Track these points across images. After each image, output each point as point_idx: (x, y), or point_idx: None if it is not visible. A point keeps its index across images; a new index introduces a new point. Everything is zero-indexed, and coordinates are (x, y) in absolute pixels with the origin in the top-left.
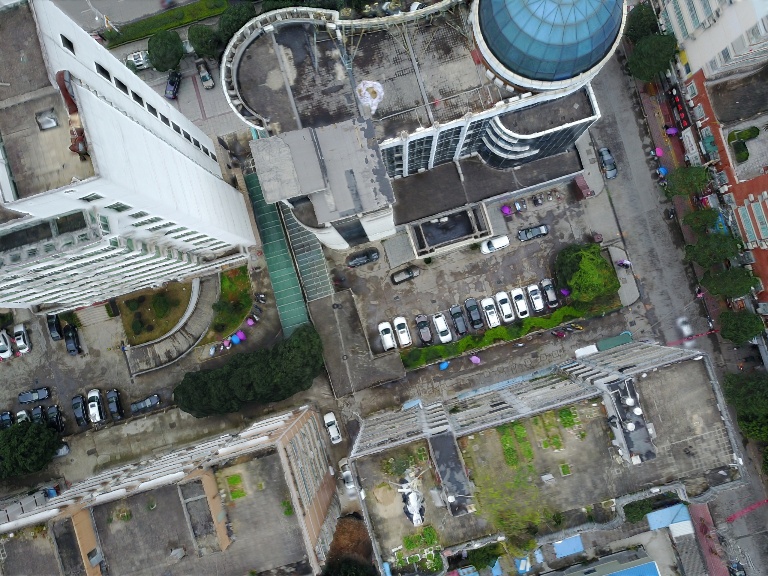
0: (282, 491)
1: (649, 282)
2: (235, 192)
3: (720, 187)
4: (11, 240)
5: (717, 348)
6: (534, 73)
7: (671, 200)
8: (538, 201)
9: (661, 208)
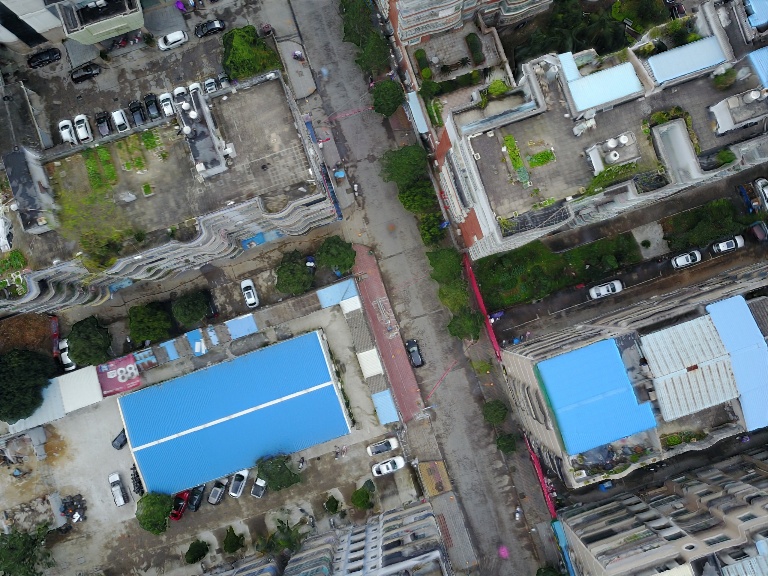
0: None
1: (326, 75)
2: None
3: None
4: None
5: (391, 136)
6: None
7: None
8: None
9: (336, 3)
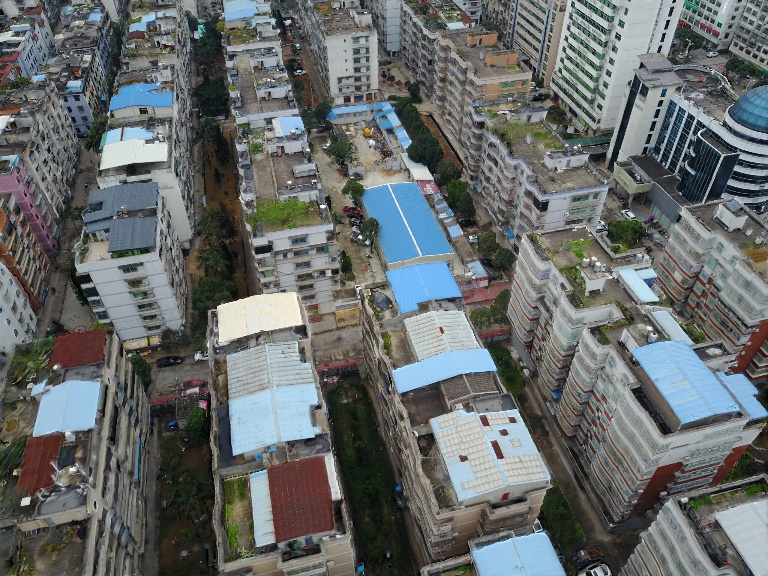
0: None
1: None
2: None
3: None
4: None
5: None
6: None
7: None
8: (662, 231)
9: None
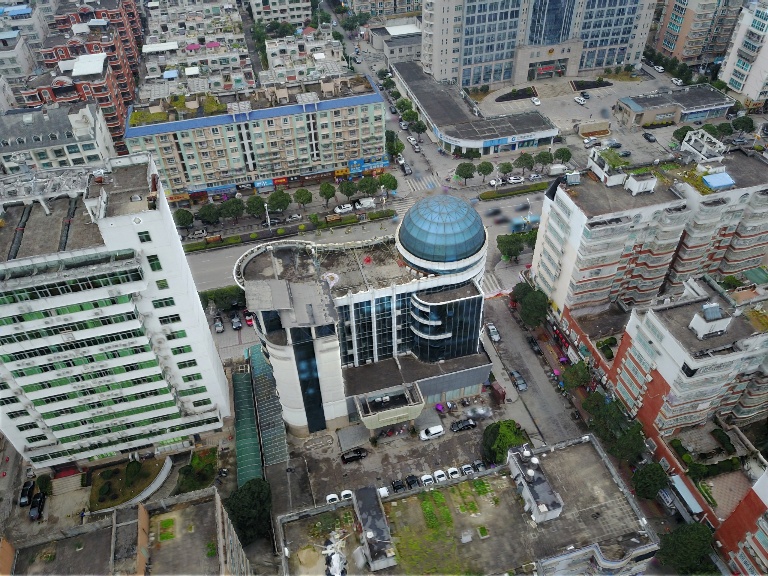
0: (209, 534)
1: None
2: (223, 371)
3: (601, 378)
4: (82, 265)
5: None
6: (432, 257)
7: (574, 406)
8: (466, 403)
9: (568, 412)
